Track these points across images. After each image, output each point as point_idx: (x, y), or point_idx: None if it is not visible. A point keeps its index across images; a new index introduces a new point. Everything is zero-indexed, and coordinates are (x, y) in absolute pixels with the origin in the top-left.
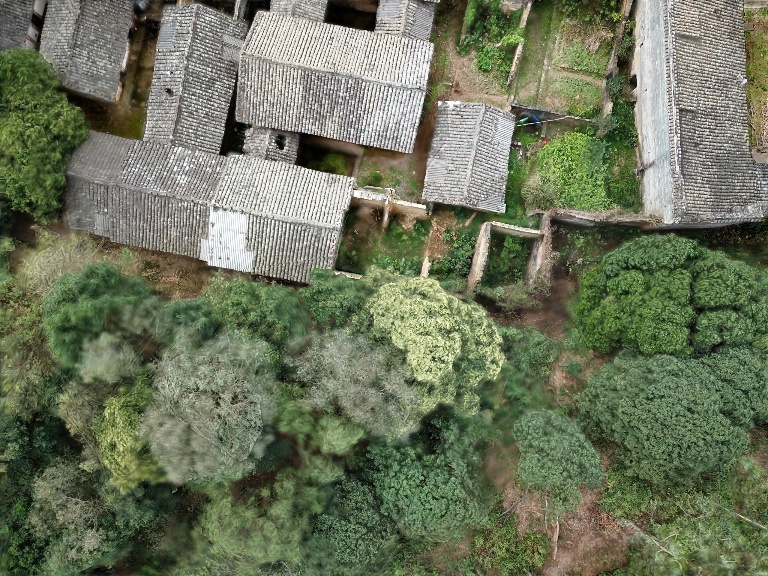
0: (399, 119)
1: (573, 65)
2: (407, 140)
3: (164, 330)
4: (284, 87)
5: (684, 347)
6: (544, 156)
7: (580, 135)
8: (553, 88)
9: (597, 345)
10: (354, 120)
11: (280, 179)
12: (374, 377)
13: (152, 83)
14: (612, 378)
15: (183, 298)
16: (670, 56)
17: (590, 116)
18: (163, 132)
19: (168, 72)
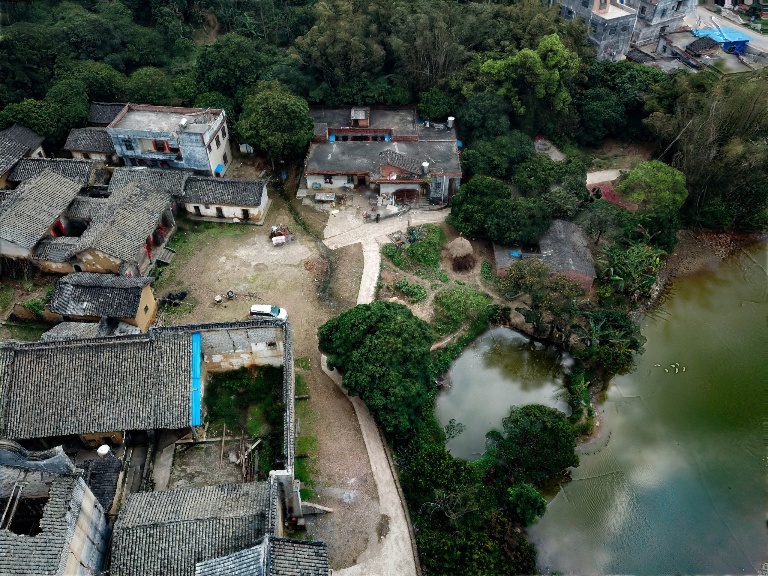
0: None
1: None
2: None
3: None
4: None
5: None
6: None
7: None
8: None
9: None
10: None
11: None
12: None
13: None
14: None
15: None
16: None
17: None
18: None
19: None
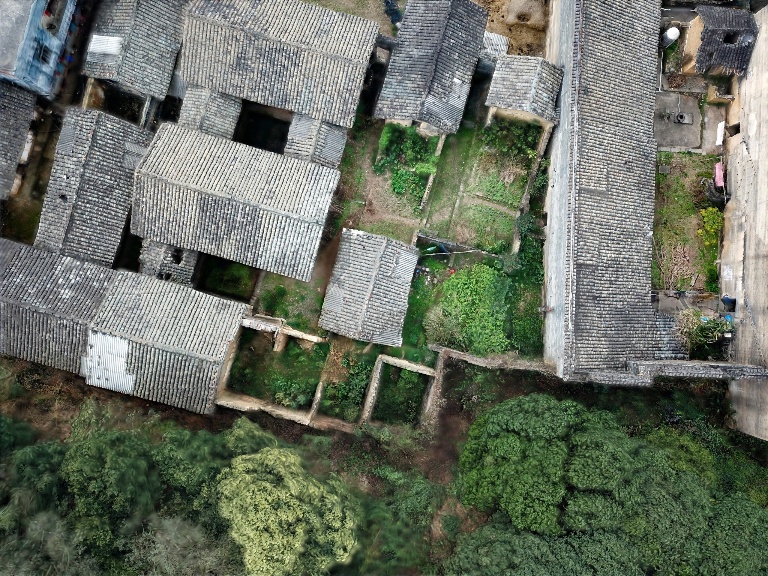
0: (297, 248)
1: (488, 194)
2: (304, 269)
3: (3, 485)
4: (180, 207)
5: (550, 525)
6: (449, 287)
7: (487, 268)
8: (466, 216)
9: (472, 503)
10: (251, 245)
11: (167, 302)
12: (201, 575)
13: (49, 184)
14: (476, 549)
15: (61, 411)
16: (572, 211)
17: (497, 252)
18: (54, 238)
19: (64, 176)
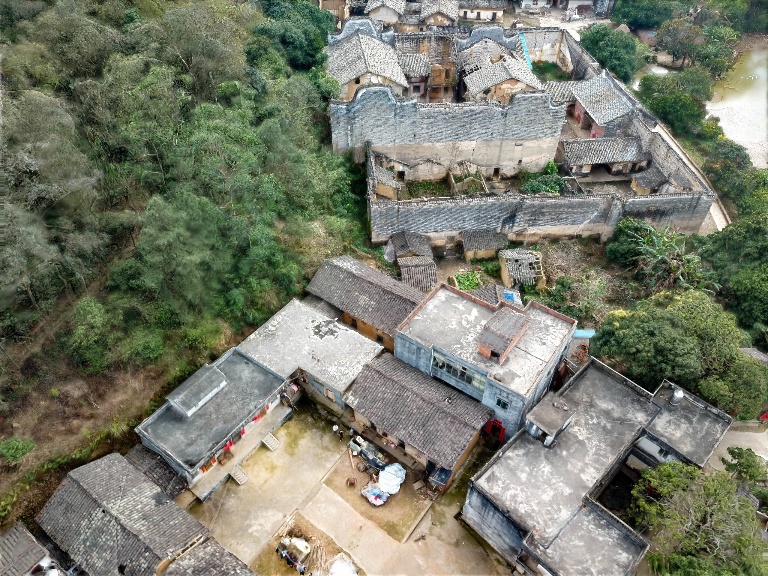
0: None
1: None
2: None
3: None
4: None
5: None
6: None
7: None
8: None
9: None
10: None
11: None
12: None
13: None
14: None
15: None
16: None
17: None
18: None
19: None
